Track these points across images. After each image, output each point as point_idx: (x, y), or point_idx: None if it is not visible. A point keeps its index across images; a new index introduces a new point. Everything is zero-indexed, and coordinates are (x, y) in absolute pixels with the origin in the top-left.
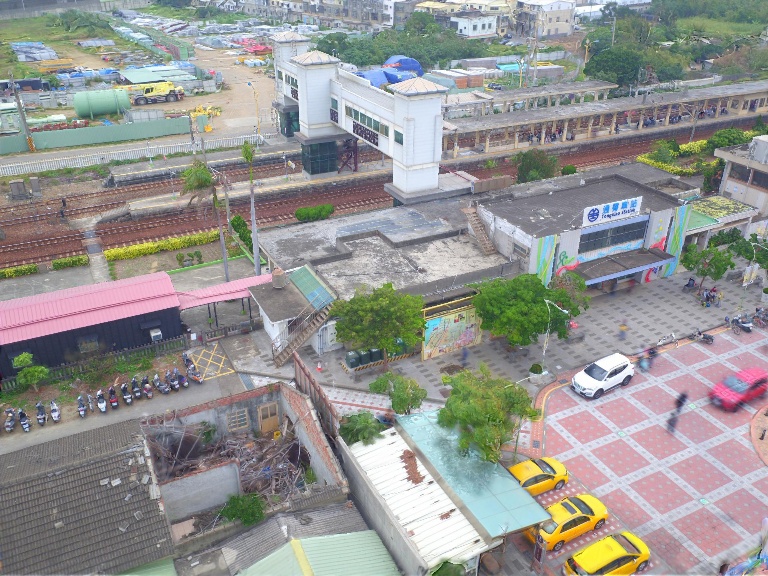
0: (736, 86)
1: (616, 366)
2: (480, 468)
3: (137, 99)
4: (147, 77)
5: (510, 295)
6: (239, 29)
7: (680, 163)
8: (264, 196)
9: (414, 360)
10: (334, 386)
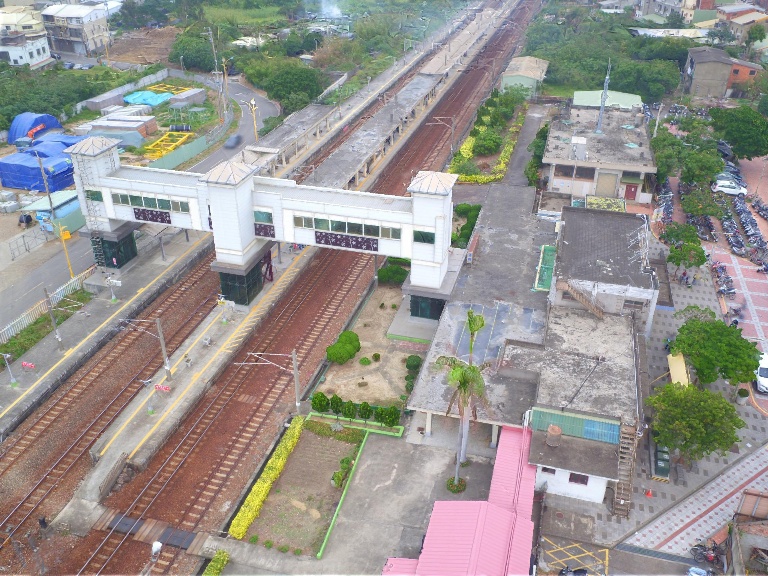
0: (411, 86)
1: None
2: None
3: None
4: None
5: None
6: None
7: None
8: (233, 354)
9: None
10: (681, 500)
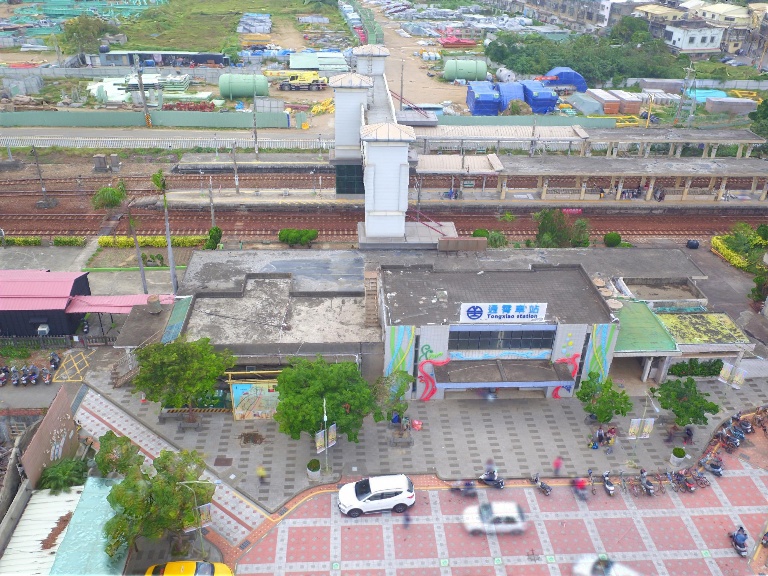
0: None
1: (384, 490)
2: (103, 555)
3: (282, 85)
4: (307, 63)
5: (303, 382)
6: (455, 16)
7: (763, 255)
8: (282, 207)
9: (229, 417)
10: (139, 421)
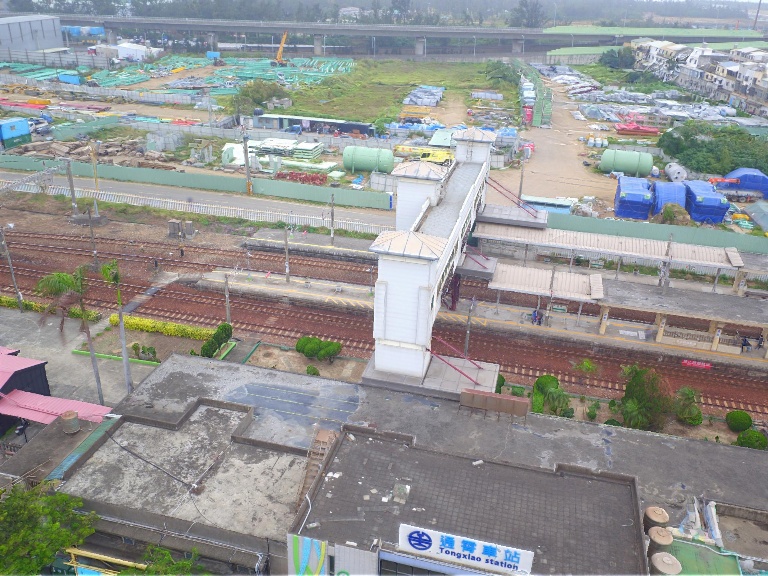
0: None
1: None
2: None
3: None
4: None
5: None
6: (646, 100)
7: None
8: (328, 306)
9: None
10: None
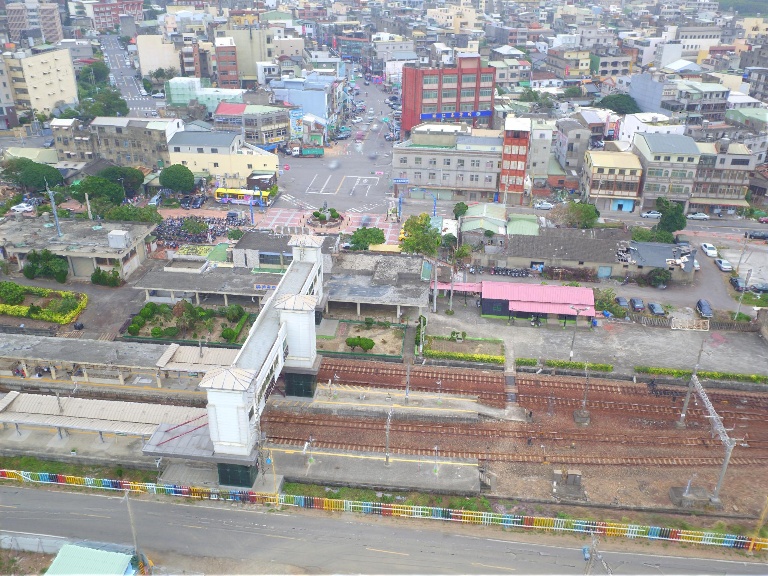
0: None
1: None
2: None
3: None
4: None
5: None
6: None
7: None
8: None
9: None
10: None
